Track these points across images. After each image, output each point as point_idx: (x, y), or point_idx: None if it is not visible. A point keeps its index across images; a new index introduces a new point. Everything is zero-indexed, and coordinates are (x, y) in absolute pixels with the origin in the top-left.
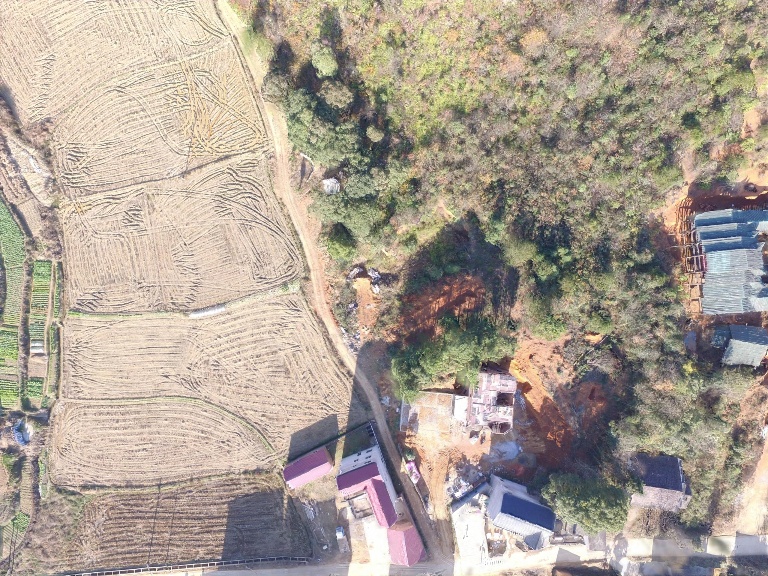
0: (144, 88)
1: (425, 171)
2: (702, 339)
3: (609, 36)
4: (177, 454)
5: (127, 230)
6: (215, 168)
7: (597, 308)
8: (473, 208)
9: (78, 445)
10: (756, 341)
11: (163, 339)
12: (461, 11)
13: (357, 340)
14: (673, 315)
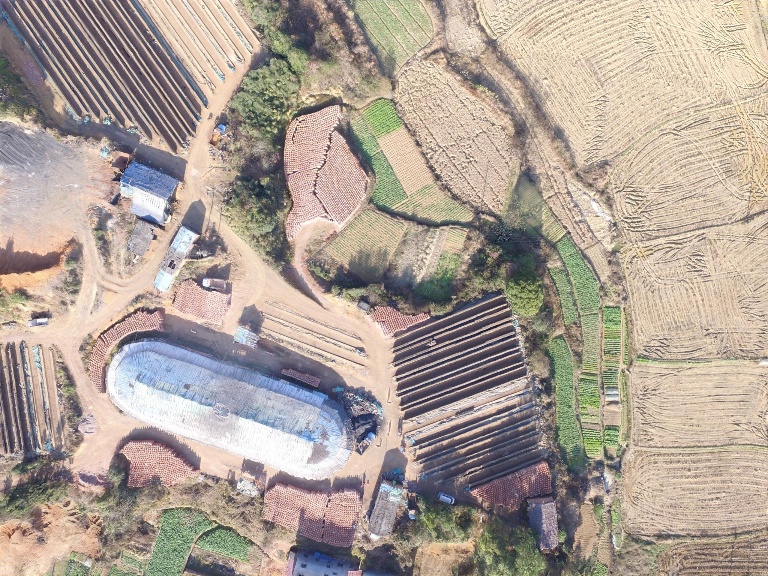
0: (699, 131)
1: None
2: None
3: None
4: (751, 503)
5: (691, 276)
6: None
7: None
8: None
9: (650, 494)
10: None
11: (732, 387)
12: None
13: None
14: None
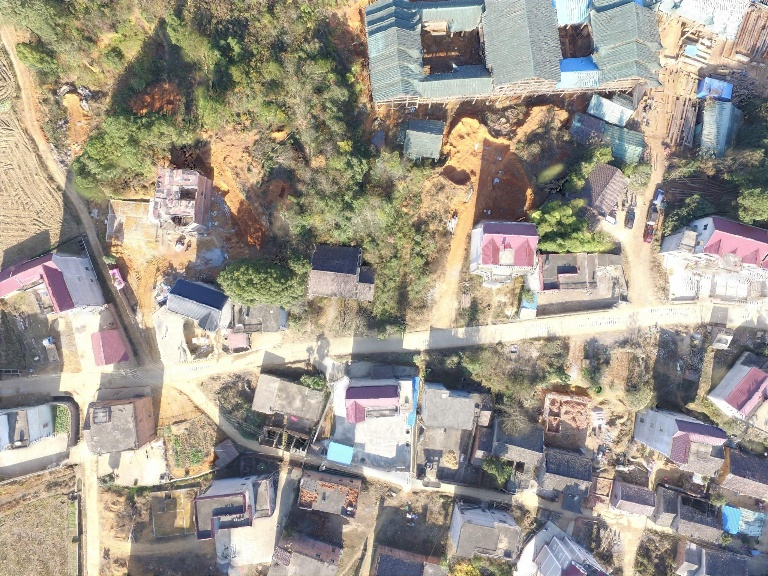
0: None
1: None
2: (389, 137)
3: None
4: None
5: None
6: None
7: (282, 106)
8: (162, 13)
9: None
10: (432, 131)
11: None
12: None
13: (67, 156)
14: (333, 97)
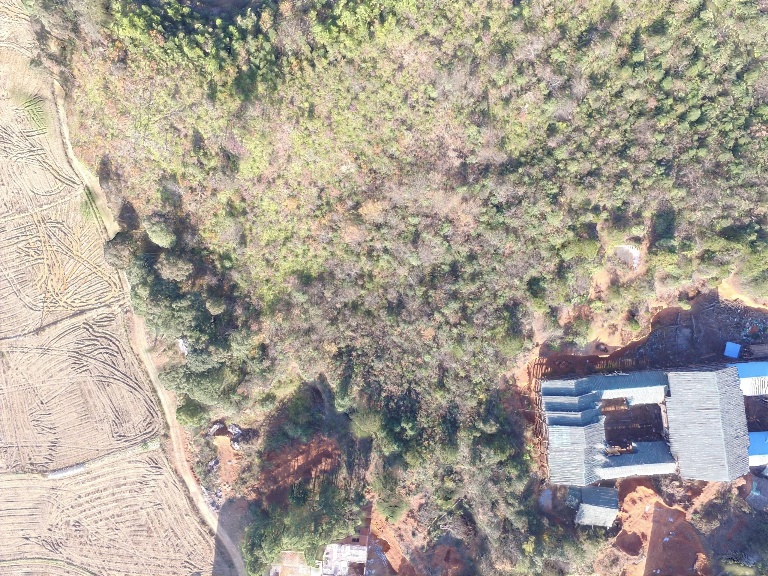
0: None
1: (269, 341)
2: (557, 498)
3: (449, 205)
4: None
5: None
6: (71, 323)
7: (449, 472)
8: (324, 372)
9: None
10: (606, 504)
11: (23, 500)
12: (299, 179)
13: (218, 498)
14: (515, 491)
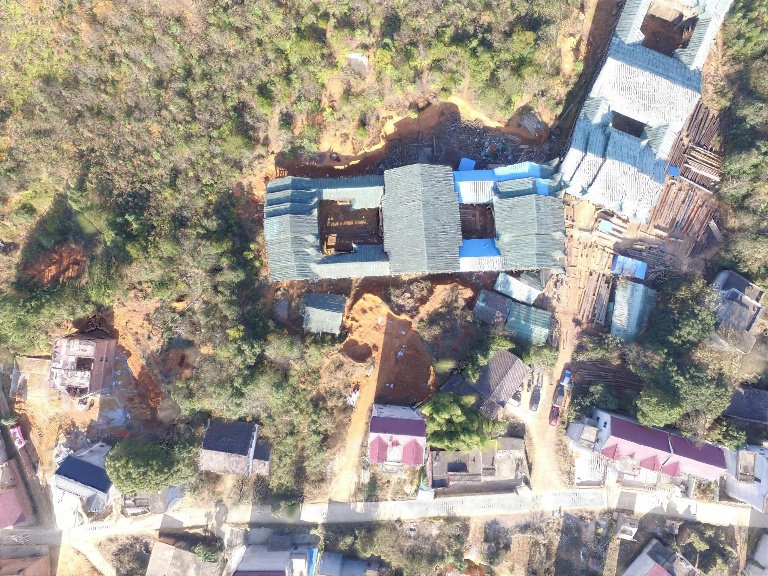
0: None
1: None
2: (291, 307)
3: (178, 5)
4: None
5: None
6: None
7: (183, 275)
8: None
9: None
10: (331, 308)
11: None
12: None
13: None
14: (226, 280)
